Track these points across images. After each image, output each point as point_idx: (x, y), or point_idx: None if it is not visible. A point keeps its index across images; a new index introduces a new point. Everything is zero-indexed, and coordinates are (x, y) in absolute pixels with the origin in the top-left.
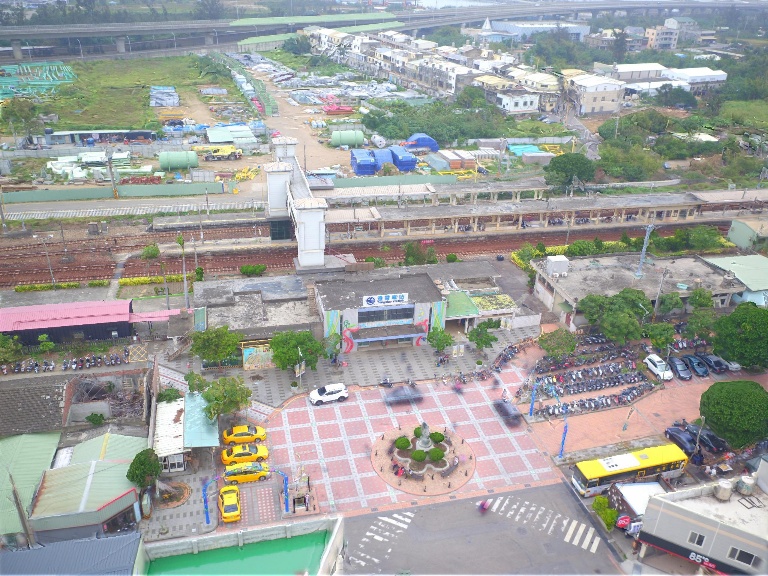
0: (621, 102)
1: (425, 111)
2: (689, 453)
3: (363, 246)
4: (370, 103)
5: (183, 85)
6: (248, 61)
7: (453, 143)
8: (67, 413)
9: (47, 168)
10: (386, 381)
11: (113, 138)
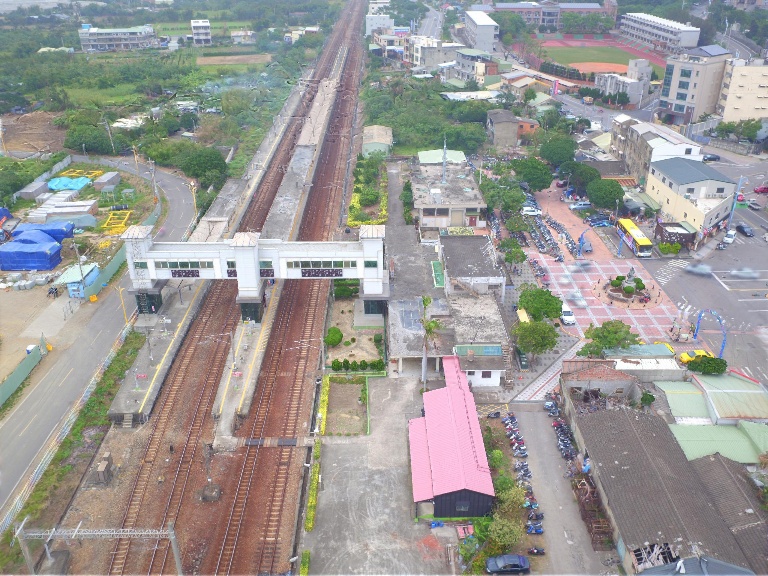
0: None
1: None
2: (613, 224)
3: (284, 283)
4: None
5: None
6: None
7: None
8: None
9: None
10: None
11: None
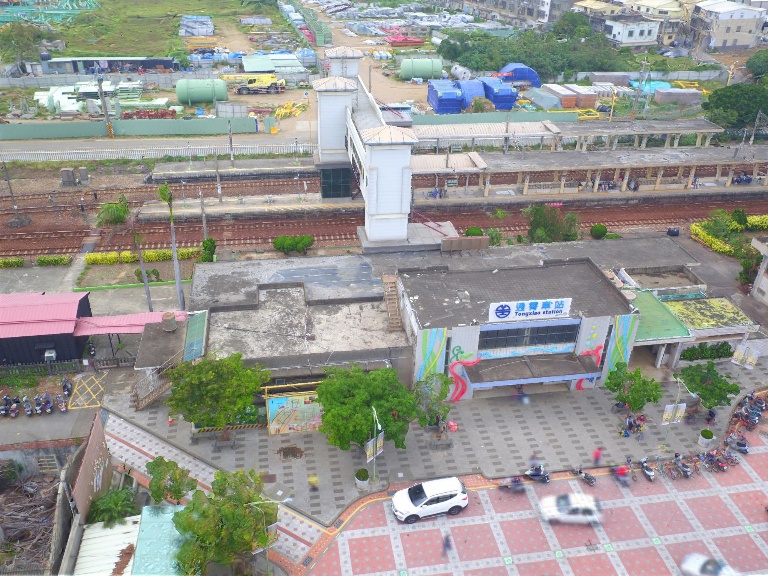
0: (758, 34)
1: (518, 38)
2: None
3: (458, 210)
4: (444, 33)
5: (221, 15)
6: None
7: (558, 77)
8: None
9: (33, 100)
10: (538, 472)
11: (125, 67)
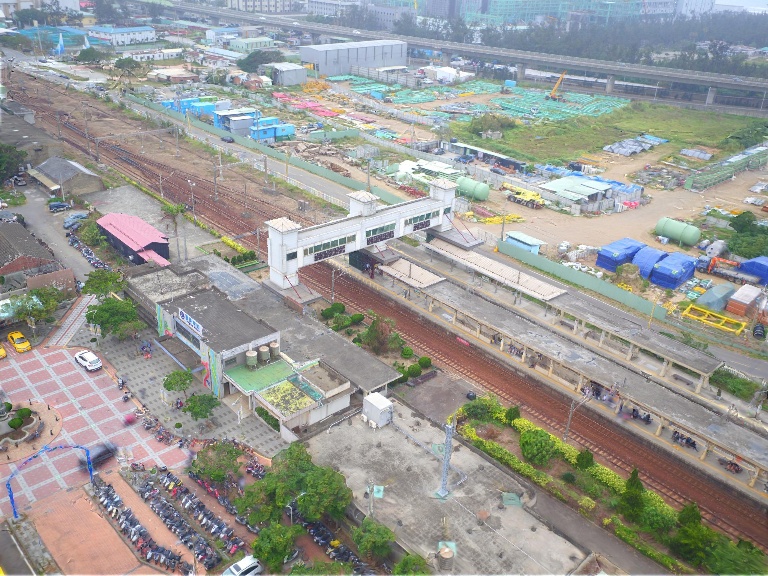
0: None
1: None
2: None
3: (406, 310)
4: None
5: (683, 141)
6: None
7: None
8: (10, 272)
9: None
10: None
11: (491, 160)
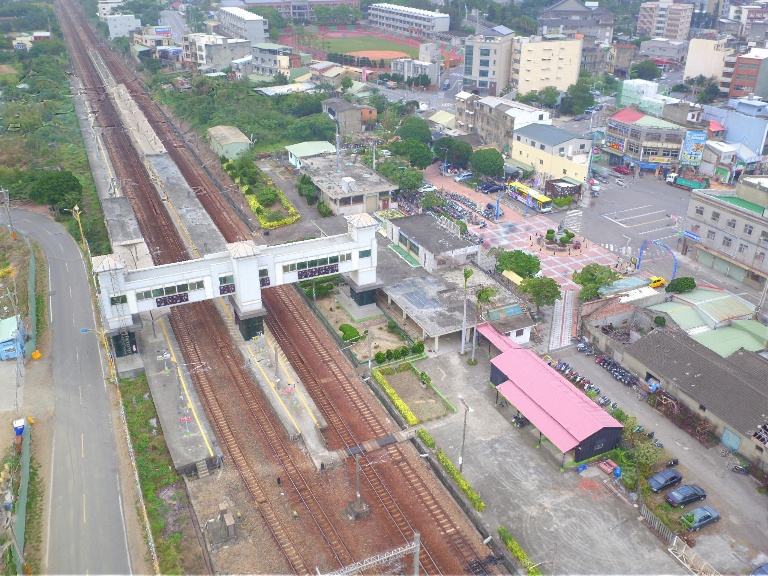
0: None
1: None
2: None
3: None
4: None
5: None
6: None
7: None
8: None
9: None
10: None
11: None
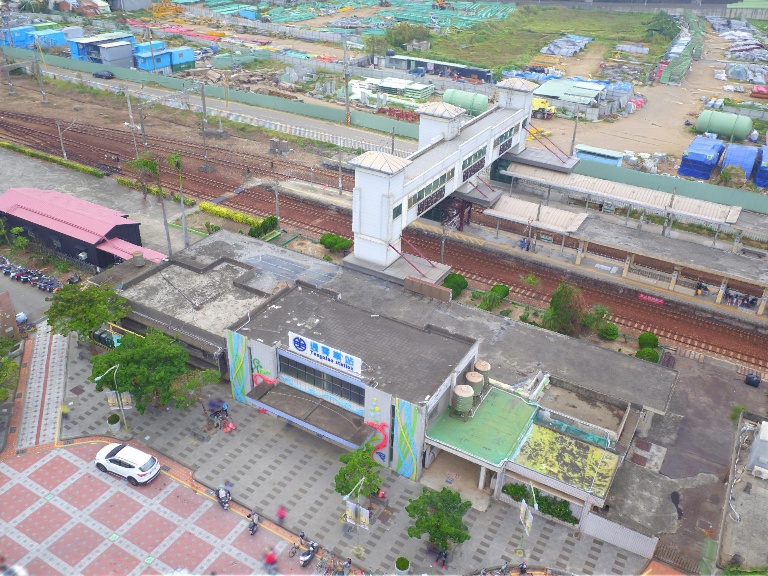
0: None
1: None
2: None
3: (538, 268)
4: None
5: (607, 38)
6: (725, 26)
7: None
8: None
9: None
10: (217, 493)
11: (446, 71)
